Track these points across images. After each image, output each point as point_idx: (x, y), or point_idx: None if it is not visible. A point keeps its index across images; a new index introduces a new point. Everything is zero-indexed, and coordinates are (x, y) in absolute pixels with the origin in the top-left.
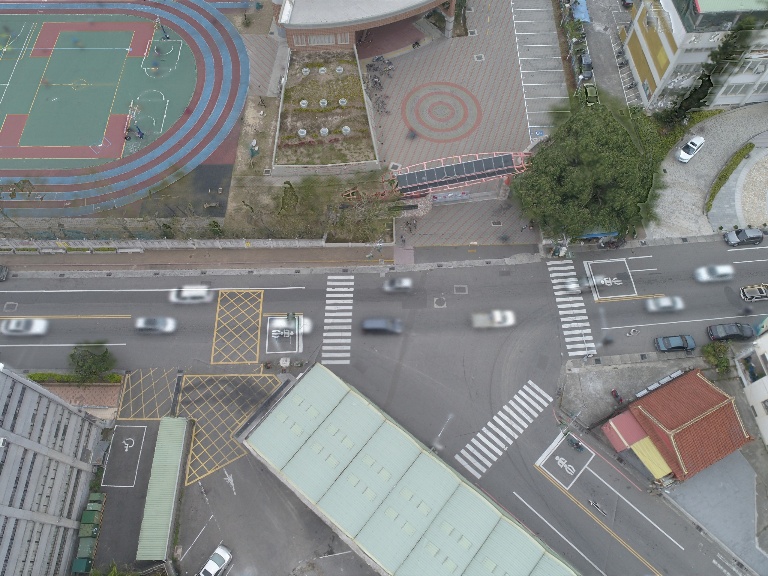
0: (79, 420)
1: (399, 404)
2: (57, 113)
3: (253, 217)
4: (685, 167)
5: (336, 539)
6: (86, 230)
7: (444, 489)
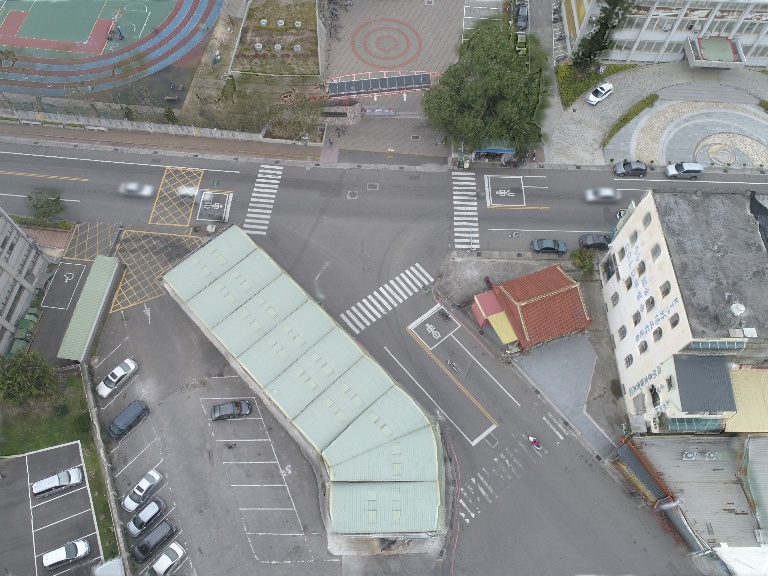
0: (27, 244)
1: (301, 270)
2: (53, 13)
3: (199, 103)
4: (593, 109)
5: (227, 366)
6: (61, 108)
7: (319, 329)
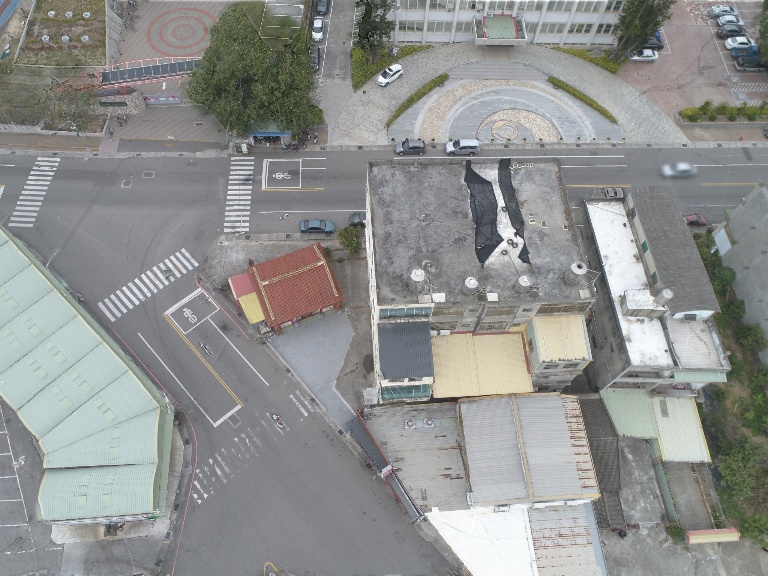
0: None
1: (64, 260)
2: None
3: None
4: (383, 90)
5: None
6: None
7: (59, 317)
